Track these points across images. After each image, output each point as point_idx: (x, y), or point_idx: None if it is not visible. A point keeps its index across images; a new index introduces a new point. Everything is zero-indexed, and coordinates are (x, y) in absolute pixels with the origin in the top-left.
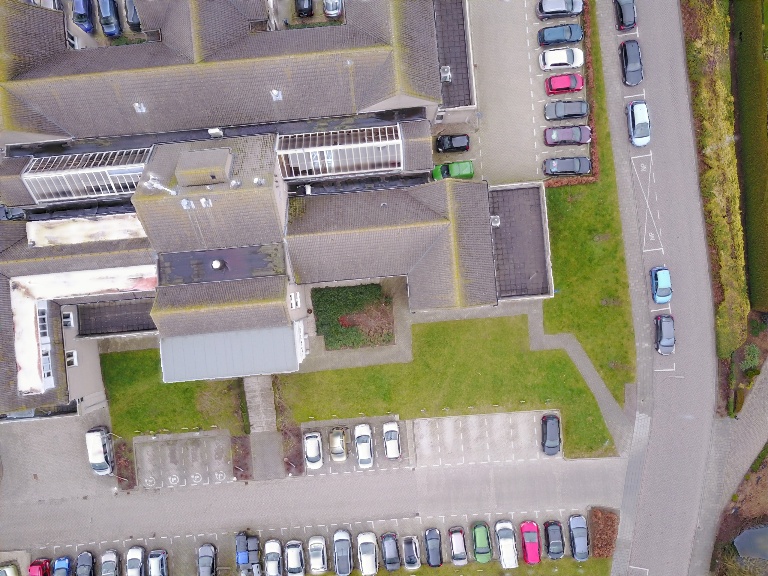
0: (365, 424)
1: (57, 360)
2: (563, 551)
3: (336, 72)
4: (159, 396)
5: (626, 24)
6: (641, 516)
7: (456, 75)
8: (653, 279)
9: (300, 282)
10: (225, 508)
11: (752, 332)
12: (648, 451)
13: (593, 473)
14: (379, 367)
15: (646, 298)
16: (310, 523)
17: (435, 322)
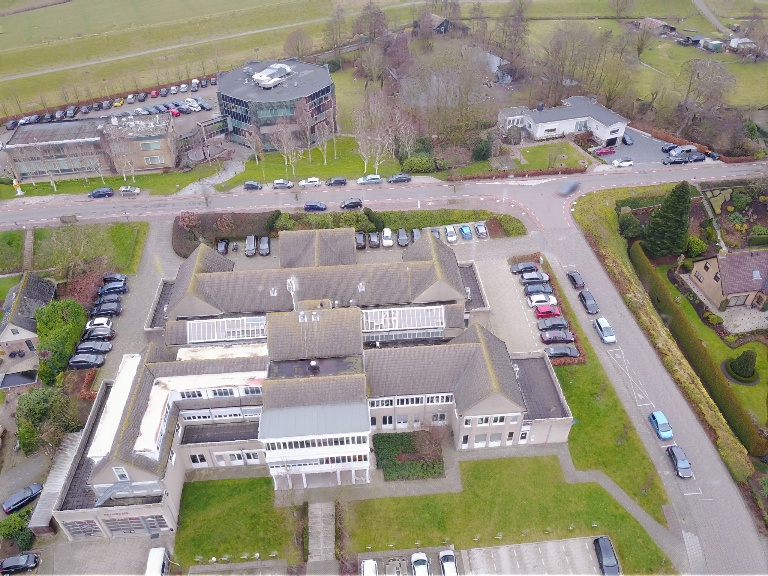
0: (421, 552)
1: (166, 444)
2: None
3: (400, 274)
4: (227, 522)
5: (578, 284)
6: None
7: (474, 298)
8: (652, 421)
9: (370, 396)
10: None
11: (759, 469)
12: (709, 571)
13: None
14: (432, 496)
15: (653, 437)
16: None
17: (479, 460)
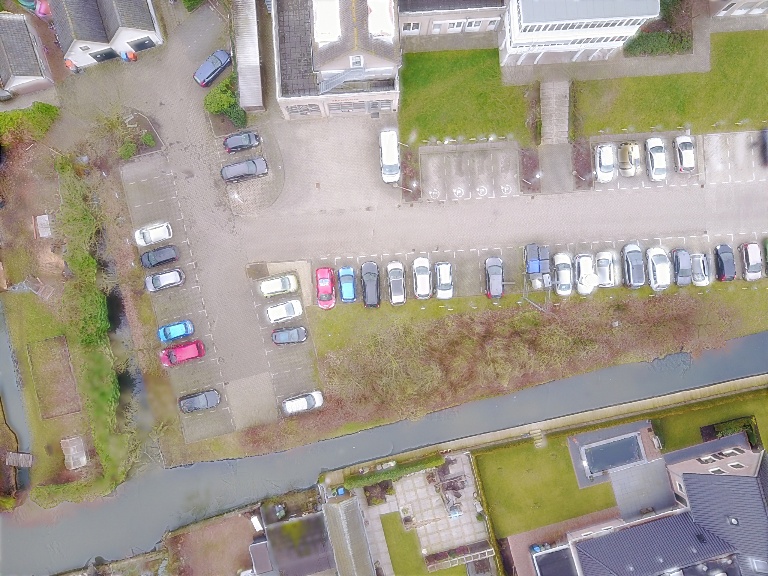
0: None
1: None
2: None
3: None
4: (451, 102)
5: None
6: None
7: None
8: None
9: None
10: (510, 222)
11: None
12: None
13: None
14: (676, 76)
15: None
16: (597, 239)
17: (734, 31)
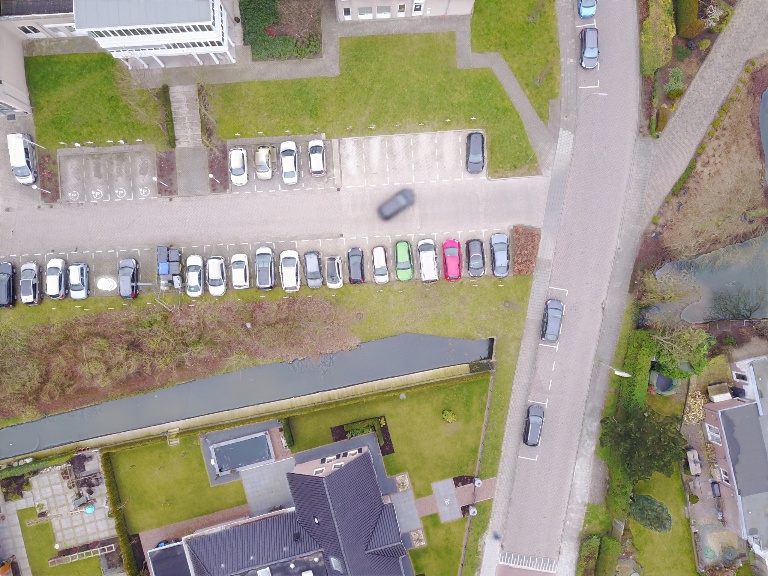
0: (291, 141)
1: None
2: (484, 269)
3: None
4: (84, 104)
5: None
6: (562, 235)
7: None
8: None
9: None
10: (148, 224)
11: (677, 56)
12: (570, 169)
13: (516, 192)
14: (306, 80)
15: (572, 13)
16: (233, 241)
17: (363, 36)
